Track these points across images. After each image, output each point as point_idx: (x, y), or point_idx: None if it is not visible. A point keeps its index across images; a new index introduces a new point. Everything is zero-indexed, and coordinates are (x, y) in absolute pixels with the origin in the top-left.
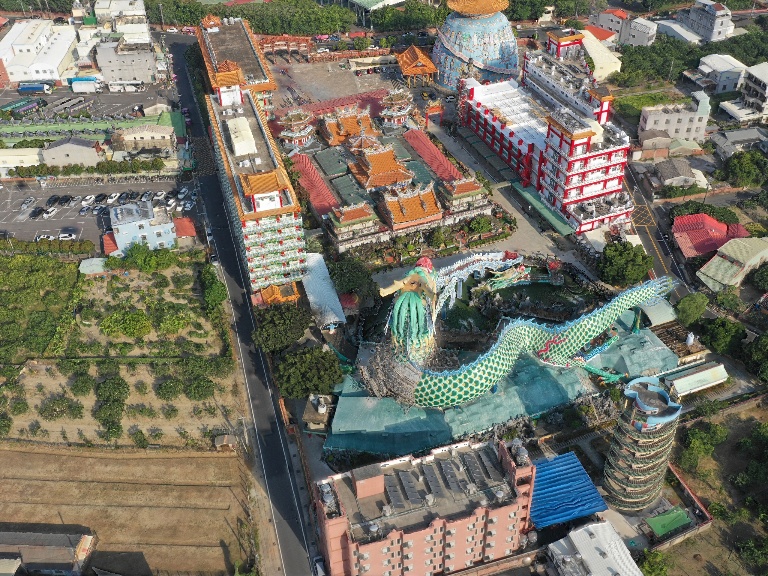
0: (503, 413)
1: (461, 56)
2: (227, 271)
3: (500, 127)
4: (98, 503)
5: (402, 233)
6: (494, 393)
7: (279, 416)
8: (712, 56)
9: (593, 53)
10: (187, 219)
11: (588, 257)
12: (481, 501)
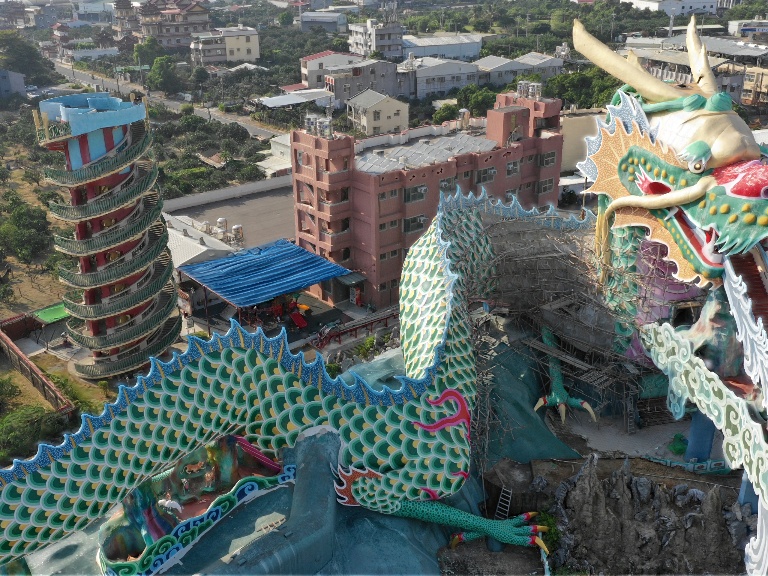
0: None
1: None
2: None
3: None
4: None
5: None
6: None
7: None
8: None
9: None
10: None
11: None
12: (359, 157)
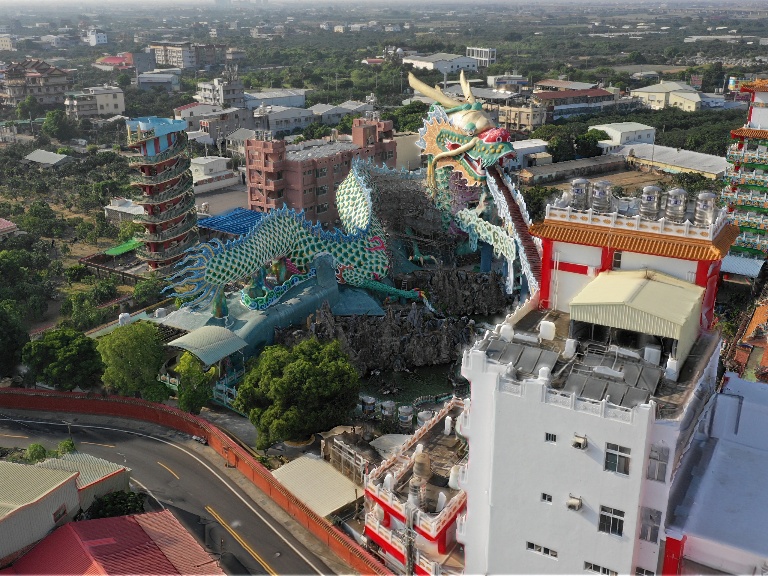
0: None
1: None
2: None
3: None
4: None
5: None
6: None
7: None
8: None
9: None
10: None
11: None
12: None
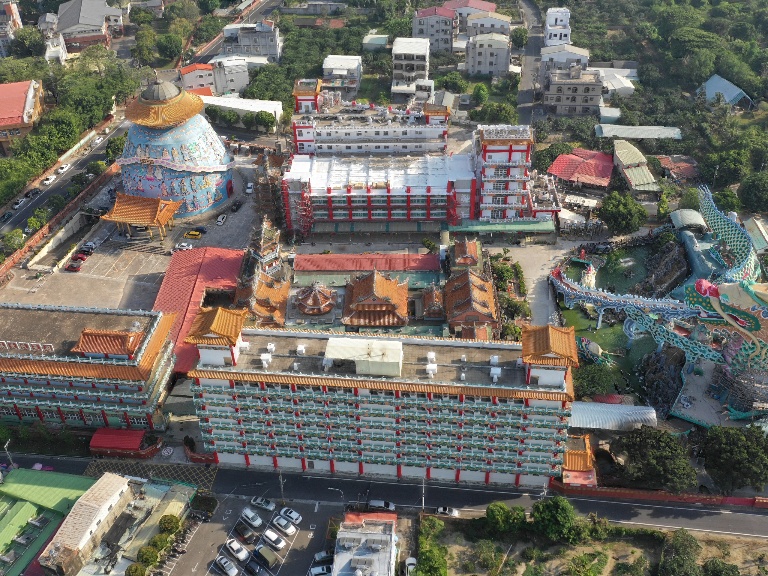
0: None
1: (204, 169)
2: (475, 505)
3: (385, 193)
4: None
5: None
6: None
7: (767, 513)
8: (328, 61)
9: (249, 108)
10: (350, 518)
11: (587, 230)
12: None
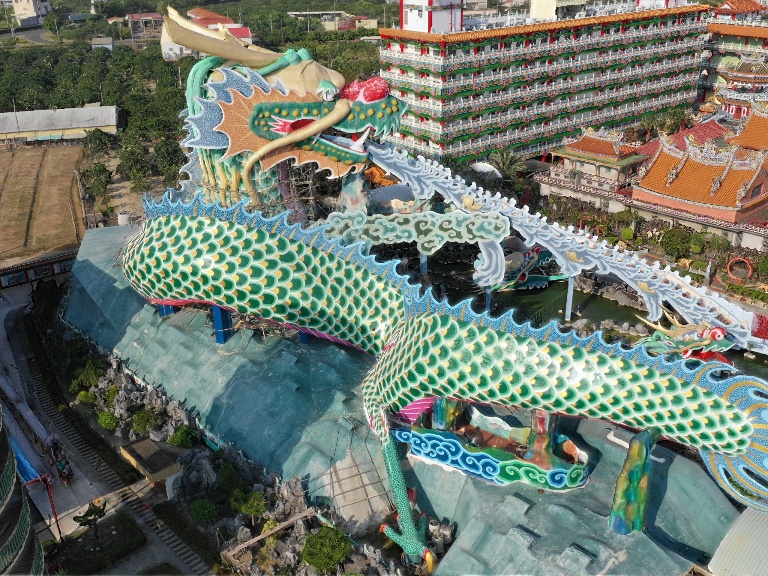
0: (185, 381)
1: None
2: None
3: None
4: (4, 199)
5: (647, 214)
6: (219, 342)
7: None
8: None
9: None
10: None
11: None
12: None
